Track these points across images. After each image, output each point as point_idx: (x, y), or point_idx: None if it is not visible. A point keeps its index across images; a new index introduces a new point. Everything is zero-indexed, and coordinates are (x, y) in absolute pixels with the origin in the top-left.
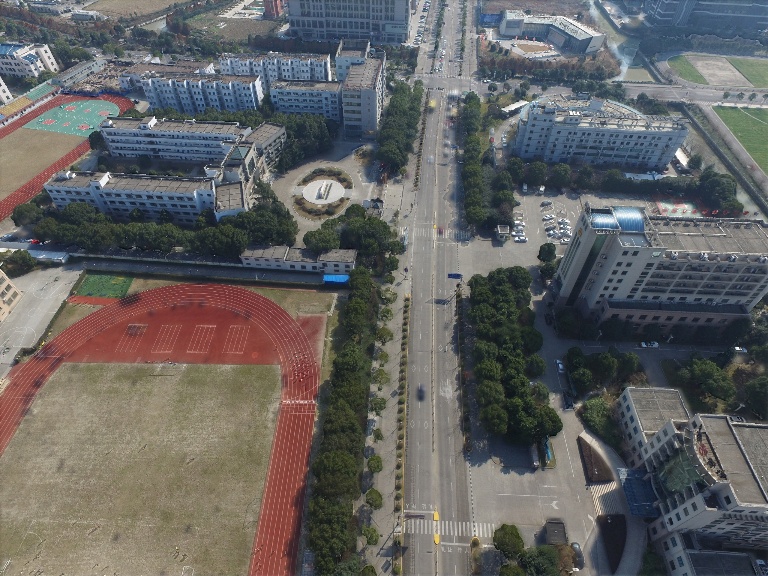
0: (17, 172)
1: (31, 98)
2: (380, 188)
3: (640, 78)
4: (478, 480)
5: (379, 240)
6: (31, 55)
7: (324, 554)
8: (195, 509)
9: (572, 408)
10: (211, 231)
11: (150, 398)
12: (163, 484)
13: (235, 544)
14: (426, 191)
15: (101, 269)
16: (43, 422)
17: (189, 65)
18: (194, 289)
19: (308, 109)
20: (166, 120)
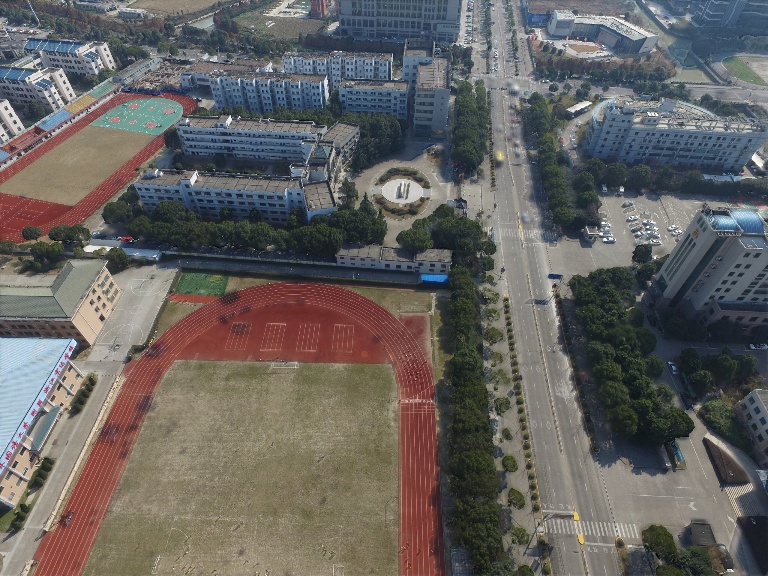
0: (93, 170)
1: (95, 96)
2: (458, 188)
3: (695, 79)
4: (611, 481)
5: (474, 240)
6: (92, 53)
7: (483, 553)
8: (334, 507)
9: (692, 409)
10: (308, 230)
11: (268, 396)
12: (297, 482)
13: (380, 542)
14: (504, 191)
15: (196, 267)
16: (166, 419)
17: (248, 64)
18: (291, 288)
19: (376, 108)
20: (241, 119)
